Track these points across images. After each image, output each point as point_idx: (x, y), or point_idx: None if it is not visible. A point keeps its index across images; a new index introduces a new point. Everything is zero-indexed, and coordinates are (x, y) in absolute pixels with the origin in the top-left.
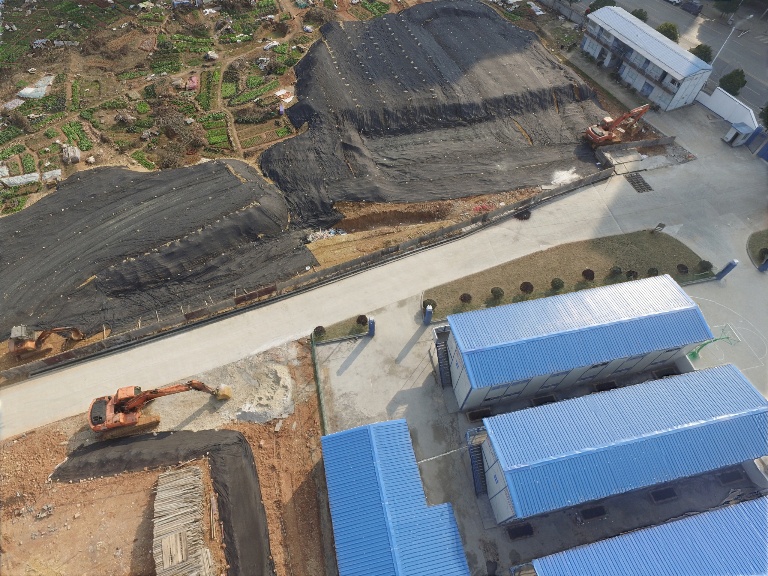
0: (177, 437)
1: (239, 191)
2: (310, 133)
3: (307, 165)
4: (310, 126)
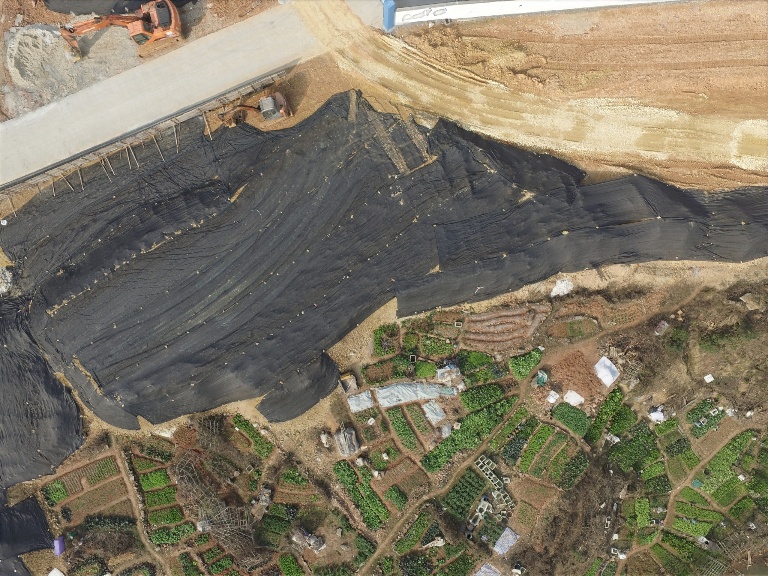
0: (104, 4)
1: (77, 338)
2: (2, 476)
3: (3, 403)
4: (2, 493)
